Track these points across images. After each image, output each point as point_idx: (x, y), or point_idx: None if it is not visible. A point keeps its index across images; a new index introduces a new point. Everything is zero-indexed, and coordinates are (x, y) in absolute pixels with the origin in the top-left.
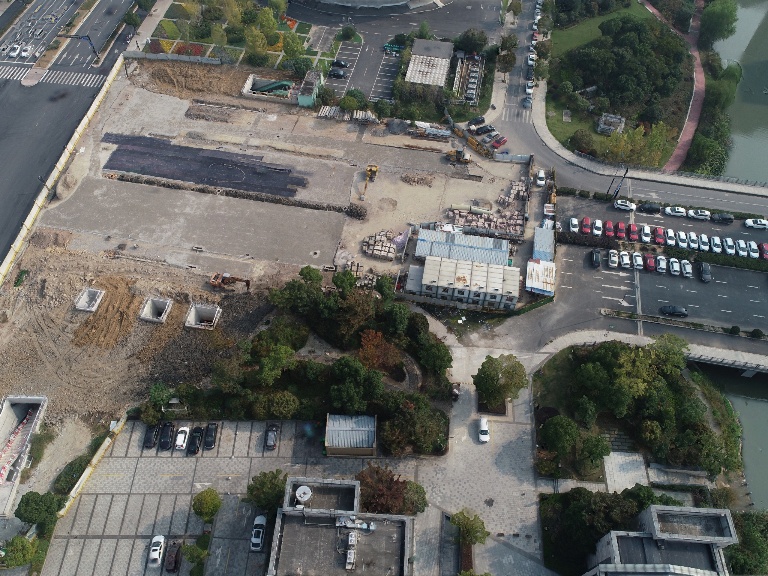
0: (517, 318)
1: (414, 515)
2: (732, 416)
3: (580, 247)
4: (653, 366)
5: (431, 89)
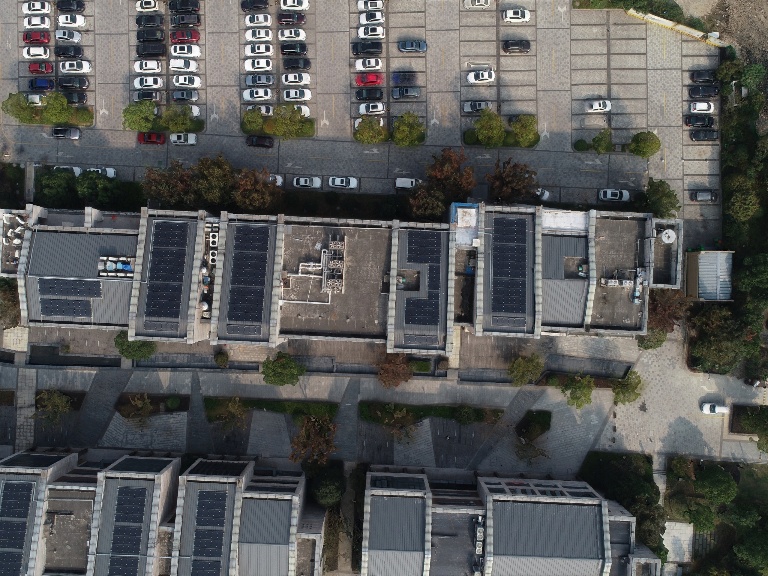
0: None
1: None
2: None
3: None
4: None
5: None
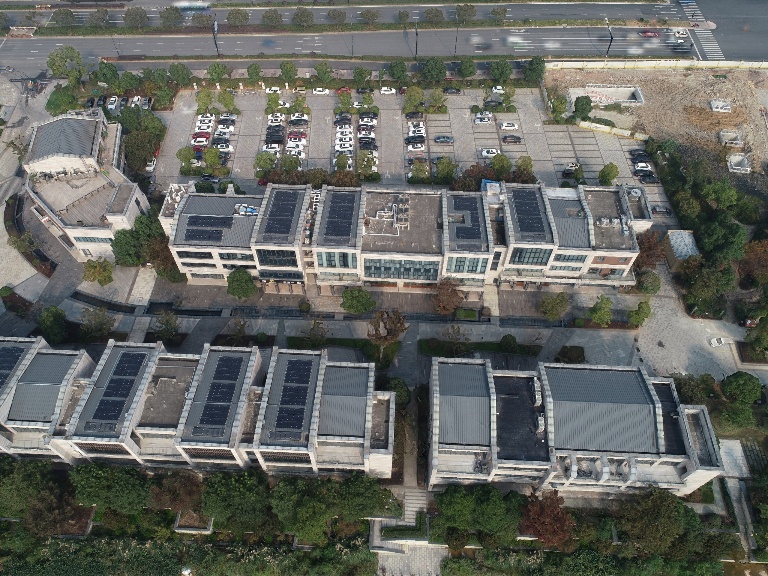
0: None
1: (635, 294)
2: None
3: None
4: None
5: None
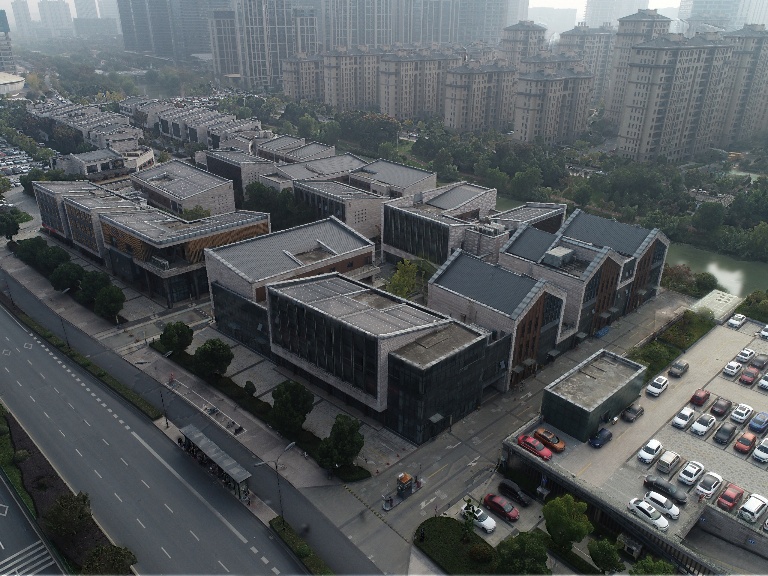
0: None
1: None
2: None
3: (100, 109)
4: None
5: (22, 100)
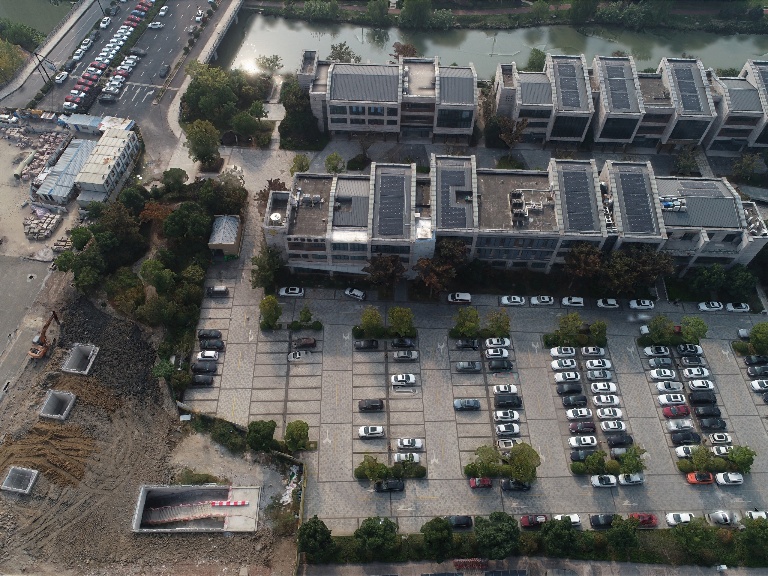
0: (147, 147)
1: None
2: (241, 71)
3: (92, 107)
4: (210, 69)
5: None
